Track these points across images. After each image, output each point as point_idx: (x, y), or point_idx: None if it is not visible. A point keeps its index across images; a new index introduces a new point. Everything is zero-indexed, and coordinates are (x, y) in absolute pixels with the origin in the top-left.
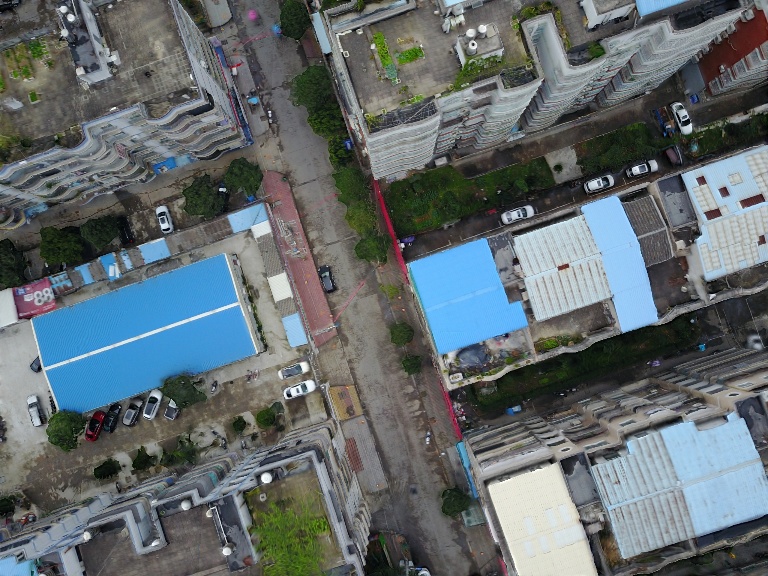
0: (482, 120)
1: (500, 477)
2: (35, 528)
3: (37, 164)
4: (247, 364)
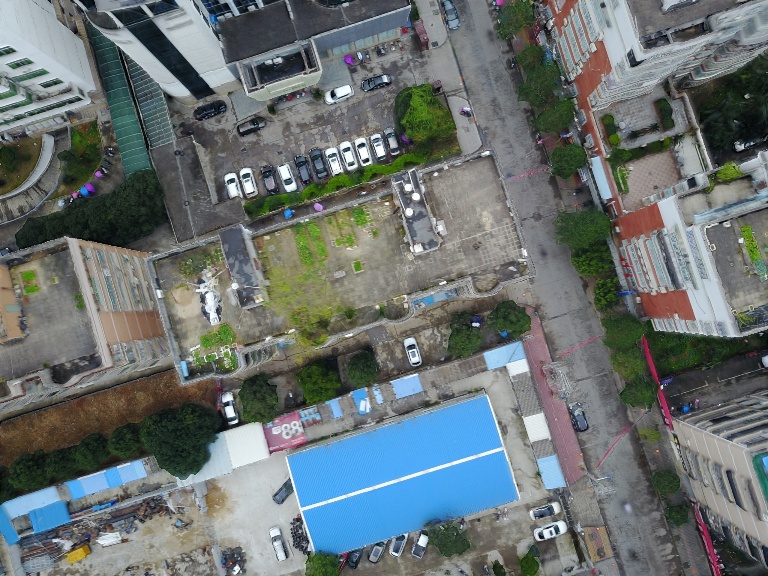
0: None
1: None
2: None
3: None
4: None
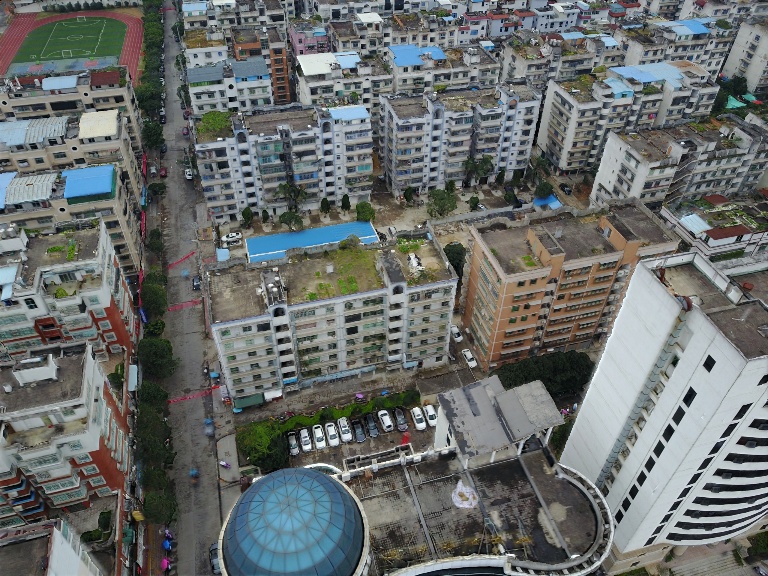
0: None
1: (110, 140)
2: (357, 154)
3: None
4: None
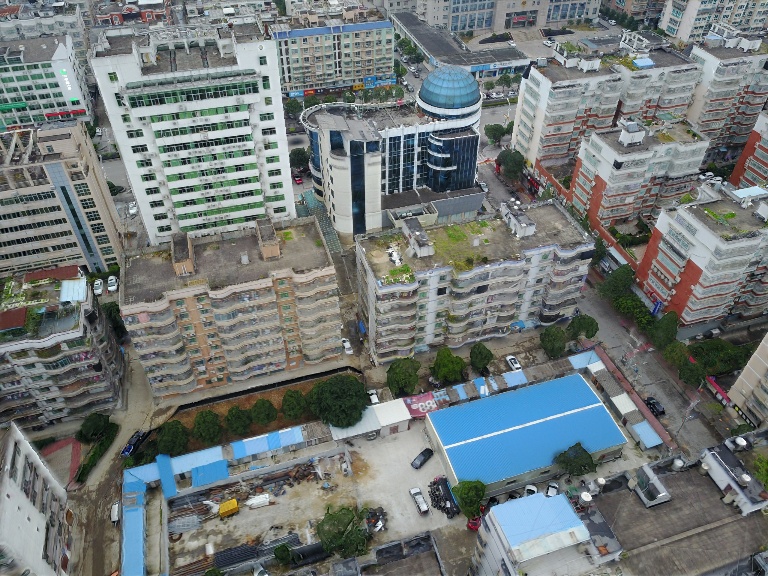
0: (764, 272)
1: None
2: None
3: (488, 274)
4: (607, 467)
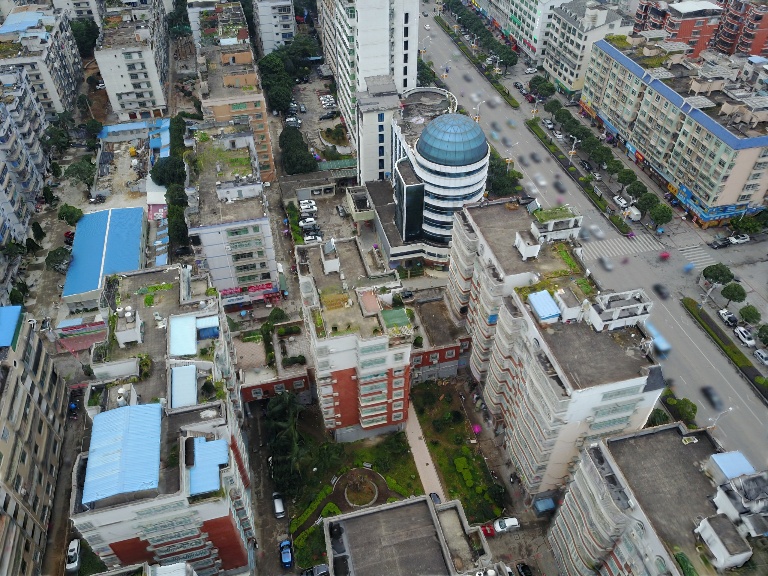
0: None
1: None
2: None
3: None
4: None
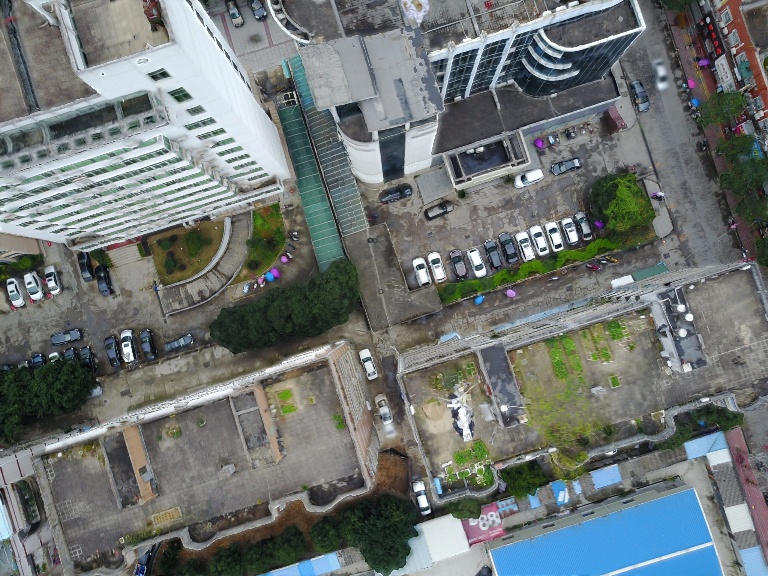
0: None
1: None
2: None
3: None
4: None
